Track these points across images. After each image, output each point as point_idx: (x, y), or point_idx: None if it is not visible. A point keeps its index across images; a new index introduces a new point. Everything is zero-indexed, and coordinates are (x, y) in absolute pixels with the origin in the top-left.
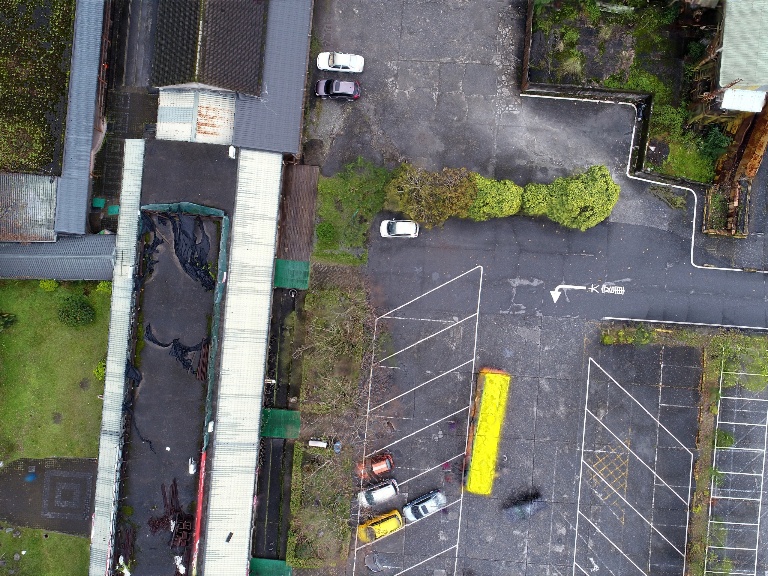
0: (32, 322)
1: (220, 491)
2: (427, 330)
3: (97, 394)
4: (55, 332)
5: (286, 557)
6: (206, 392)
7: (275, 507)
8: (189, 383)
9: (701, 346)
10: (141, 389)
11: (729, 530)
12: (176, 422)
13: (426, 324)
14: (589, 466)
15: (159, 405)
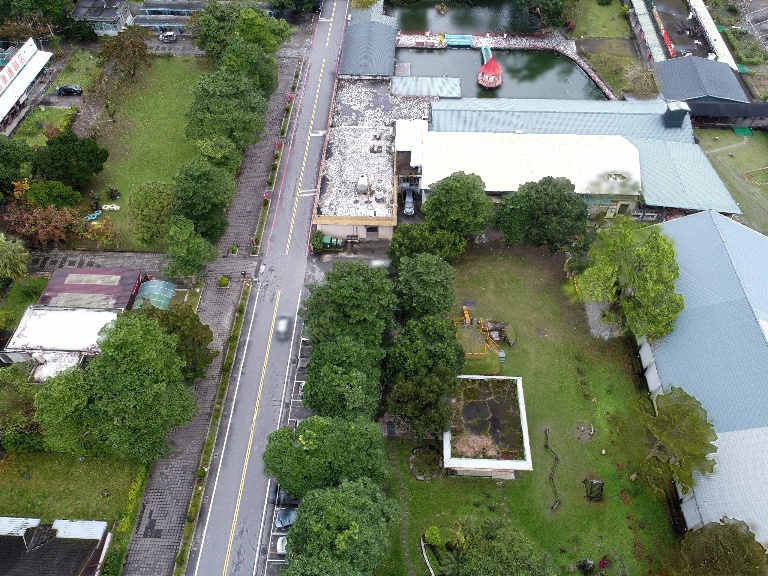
0: (583, 3)
1: None
2: (765, 6)
3: None
4: None
5: None
6: None
7: None
8: None
9: None
10: (653, 1)
11: None
12: (674, 8)
13: (763, 5)
14: None
15: None
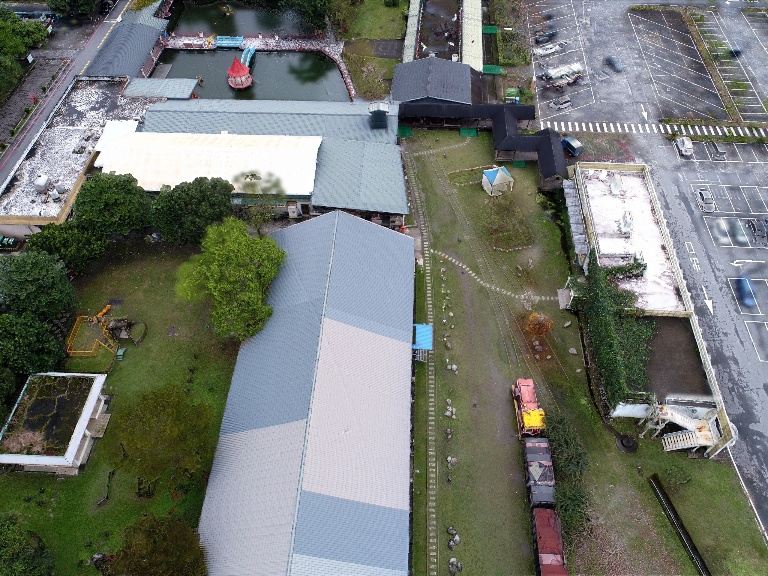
0: (370, 5)
1: (467, 29)
2: None
3: (399, 23)
4: (380, 8)
5: (499, 59)
6: (458, 1)
7: (489, 52)
8: (450, 1)
9: (678, 10)
10: None
11: (721, 55)
12: None
13: None
14: (641, 39)
15: (437, 6)
